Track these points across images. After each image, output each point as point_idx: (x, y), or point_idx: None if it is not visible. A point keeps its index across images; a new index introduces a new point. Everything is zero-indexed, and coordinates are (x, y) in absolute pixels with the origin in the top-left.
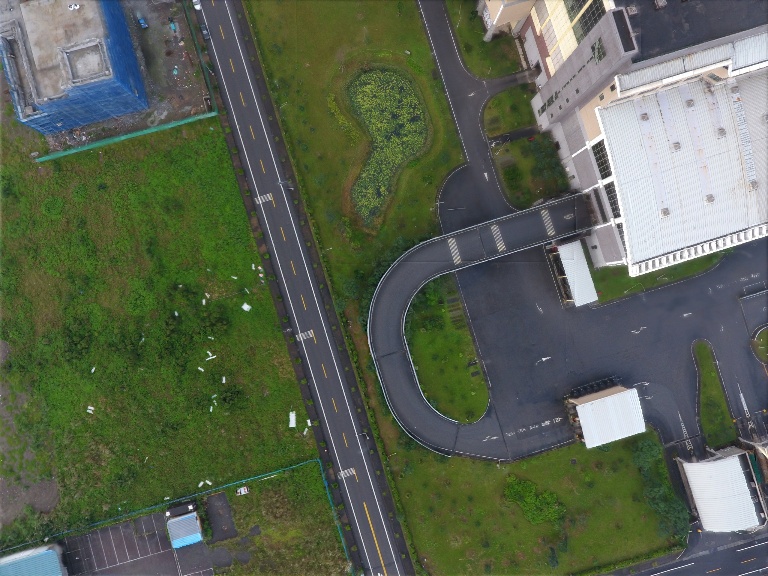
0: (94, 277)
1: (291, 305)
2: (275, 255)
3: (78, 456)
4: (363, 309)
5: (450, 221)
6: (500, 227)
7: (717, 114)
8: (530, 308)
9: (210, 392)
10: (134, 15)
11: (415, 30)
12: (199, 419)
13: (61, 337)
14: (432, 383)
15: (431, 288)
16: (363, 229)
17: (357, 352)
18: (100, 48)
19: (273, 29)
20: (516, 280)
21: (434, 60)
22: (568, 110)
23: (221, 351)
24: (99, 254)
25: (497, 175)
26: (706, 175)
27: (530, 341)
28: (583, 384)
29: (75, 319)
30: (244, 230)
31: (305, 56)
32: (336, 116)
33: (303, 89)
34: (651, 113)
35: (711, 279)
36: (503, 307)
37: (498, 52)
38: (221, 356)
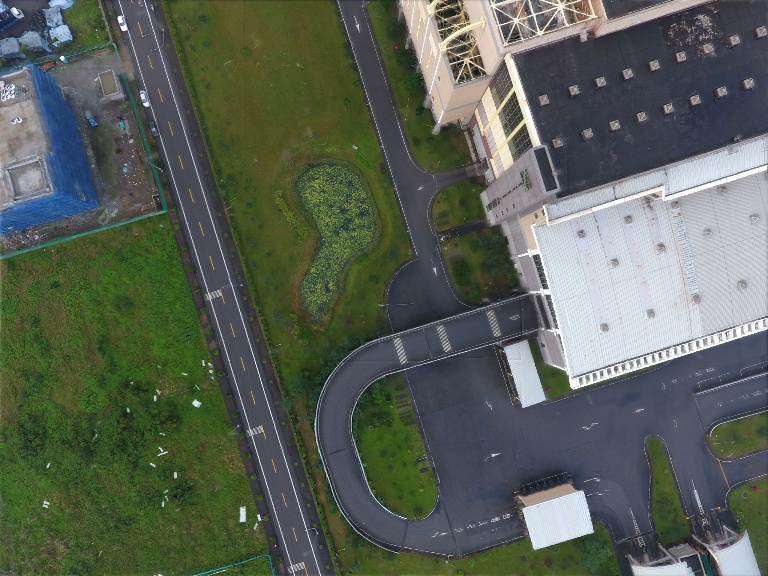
0: (48, 374)
1: (241, 401)
2: (225, 351)
3: (34, 550)
4: (310, 409)
5: (399, 317)
6: (446, 328)
7: (656, 229)
8: (479, 404)
9: (161, 488)
10: (84, 113)
11: (363, 124)
12: (151, 514)
13: (17, 434)
14: (381, 479)
15: (377, 389)
16: (311, 326)
17: (306, 448)
18: (41, 165)
19: (221, 125)
20: (465, 376)
21: (382, 154)
22: (510, 216)
23: (172, 447)
24: (52, 352)
25: (446, 270)
26: (646, 290)
27: (479, 437)
28: (533, 480)
29: (30, 416)
30: (194, 327)
31: (253, 152)
32: (284, 213)
33: (251, 185)
34: (588, 230)
35: (665, 374)
36: (452, 403)
37: (445, 147)
38: (172, 452)
